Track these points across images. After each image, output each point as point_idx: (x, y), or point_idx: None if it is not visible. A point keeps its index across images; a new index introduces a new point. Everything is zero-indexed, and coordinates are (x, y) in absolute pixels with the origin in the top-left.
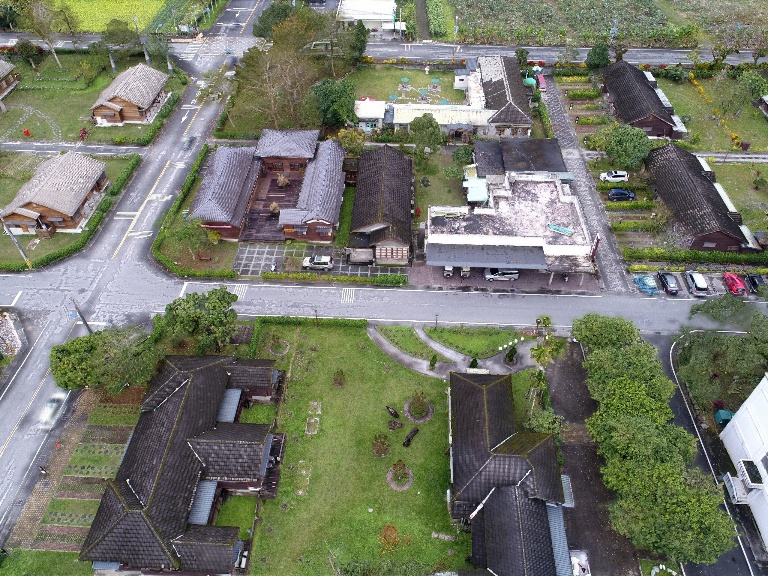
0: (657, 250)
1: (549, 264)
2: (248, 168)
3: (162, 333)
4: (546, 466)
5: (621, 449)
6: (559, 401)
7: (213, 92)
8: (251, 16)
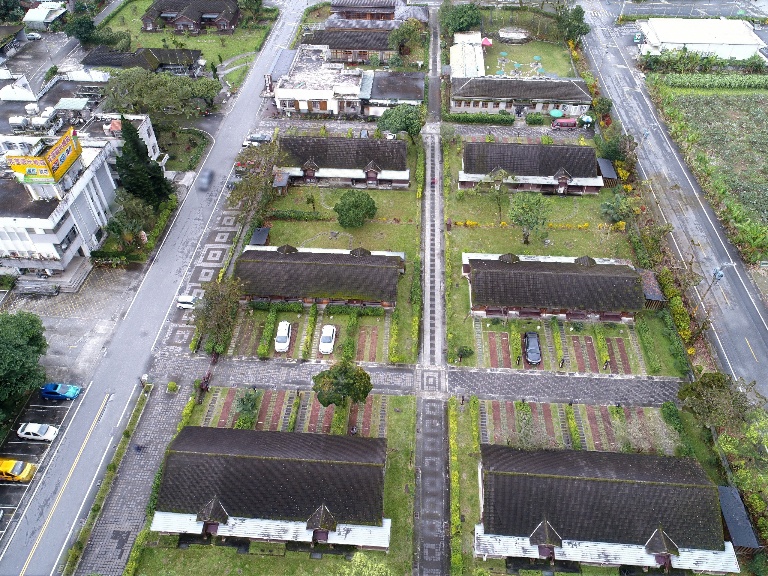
0: None
1: None
2: (382, 6)
3: (268, 11)
4: (138, 63)
5: None
6: None
7: (504, 3)
8: (648, 3)
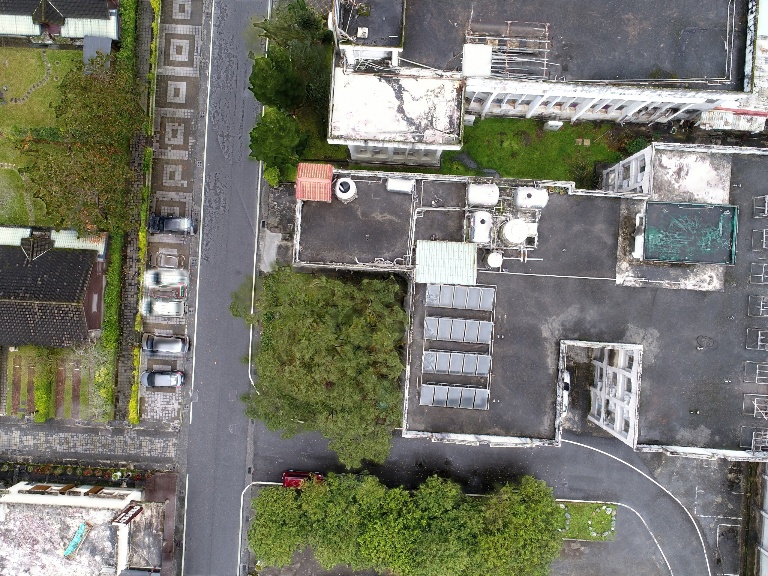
0: (101, 379)
1: (146, 564)
2: None
3: None
4: None
5: (455, 574)
6: (354, 571)
7: None
8: None
